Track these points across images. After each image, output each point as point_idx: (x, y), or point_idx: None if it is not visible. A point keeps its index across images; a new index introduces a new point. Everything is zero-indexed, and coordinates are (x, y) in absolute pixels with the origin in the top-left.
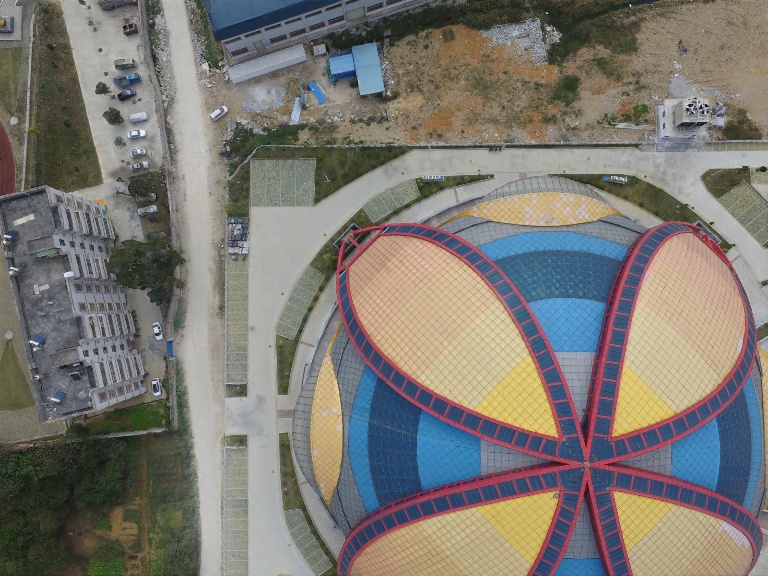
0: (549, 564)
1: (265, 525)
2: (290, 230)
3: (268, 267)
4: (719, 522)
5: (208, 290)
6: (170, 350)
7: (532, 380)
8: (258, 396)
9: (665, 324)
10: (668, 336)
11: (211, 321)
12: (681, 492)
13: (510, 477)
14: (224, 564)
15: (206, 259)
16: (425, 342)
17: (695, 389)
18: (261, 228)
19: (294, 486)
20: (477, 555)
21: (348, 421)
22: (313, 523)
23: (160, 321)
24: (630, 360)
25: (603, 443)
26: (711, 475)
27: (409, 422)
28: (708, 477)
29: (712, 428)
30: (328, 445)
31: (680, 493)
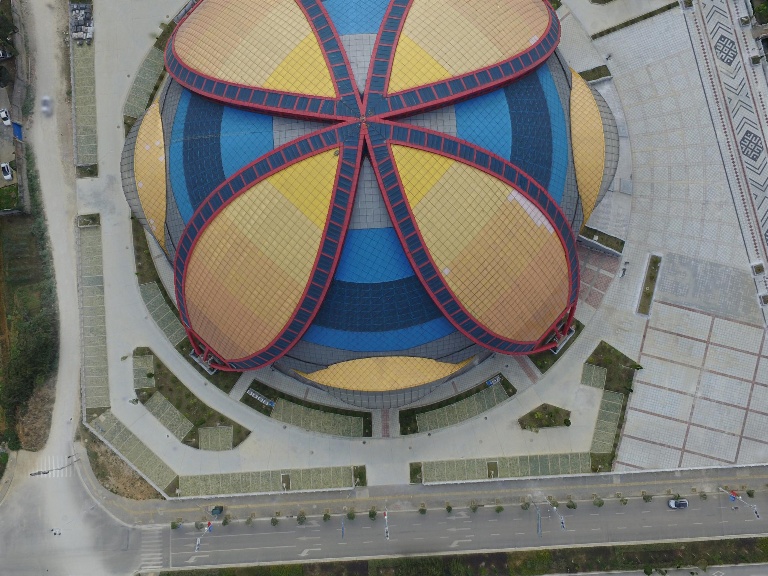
0: (337, 225)
1: (121, 300)
2: (133, 14)
3: (113, 51)
4: (508, 189)
5: (55, 77)
6: (18, 133)
7: (313, 52)
8: (109, 176)
9: (449, 7)
10: (451, 15)
11: (59, 107)
12: (460, 148)
13: (293, 141)
14: (82, 340)
15: (52, 47)
16: (223, 44)
17: (476, 59)
18: (104, 14)
19: (148, 260)
20: (274, 230)
21: (168, 149)
22: (168, 294)
23: (8, 108)
24: (409, 31)
25: (378, 99)
26: (502, 150)
27: (214, 125)
28: (499, 152)
29: (502, 107)
30: (152, 176)
31: (459, 149)
